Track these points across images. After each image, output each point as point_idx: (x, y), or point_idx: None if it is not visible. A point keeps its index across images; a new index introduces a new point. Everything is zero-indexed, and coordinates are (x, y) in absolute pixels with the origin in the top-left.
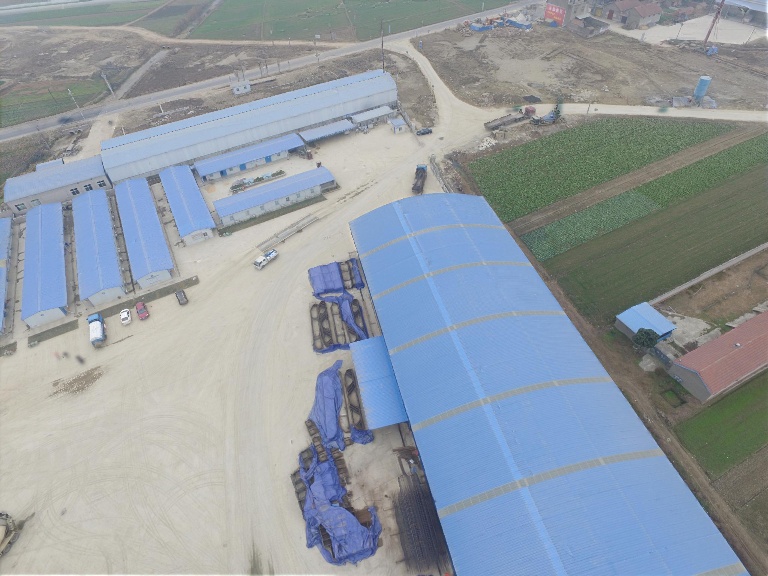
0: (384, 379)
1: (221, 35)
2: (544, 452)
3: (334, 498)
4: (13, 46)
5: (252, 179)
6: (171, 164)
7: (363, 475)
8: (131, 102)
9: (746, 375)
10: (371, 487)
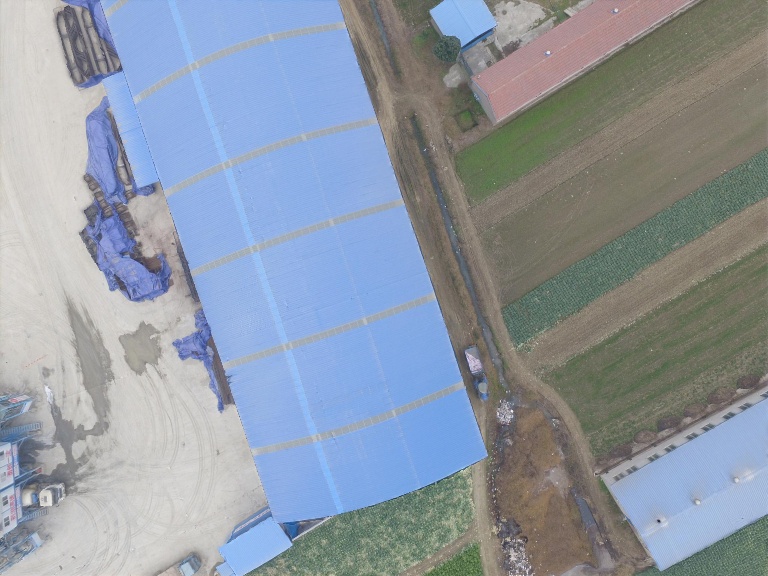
0: None
1: None
2: (277, 218)
3: (125, 250)
4: None
5: None
6: None
7: (149, 226)
8: None
9: (551, 87)
10: (158, 237)
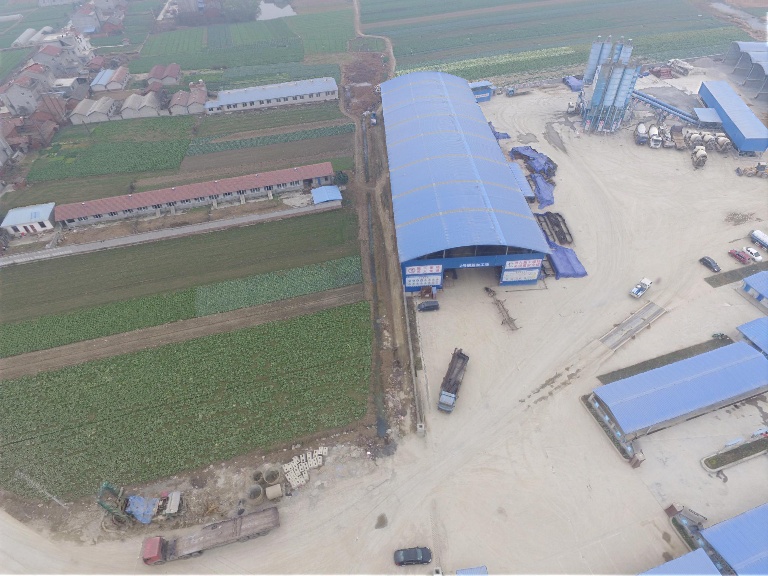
0: None
1: None
2: None
3: None
4: None
5: (756, 434)
6: None
7: None
8: None
9: None
10: None
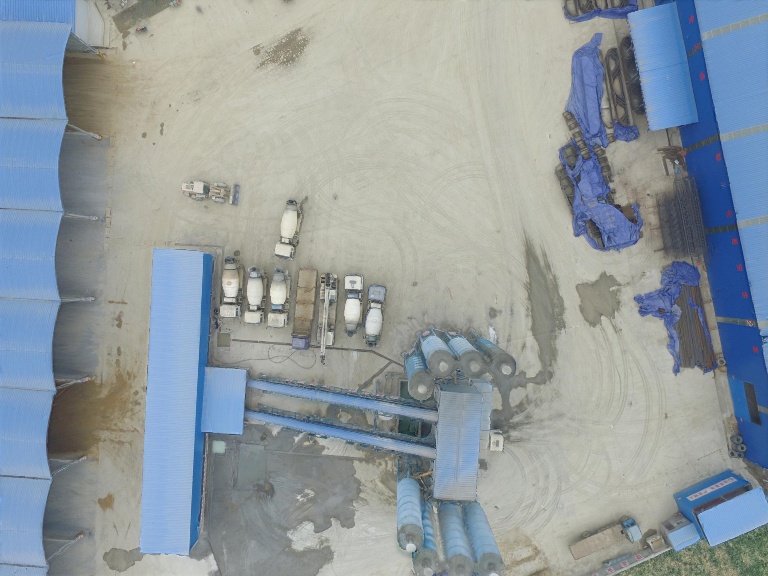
0: (671, 68)
1: None
2: None
3: (599, 195)
4: None
5: None
6: None
7: (626, 174)
8: None
9: None
10: (634, 186)
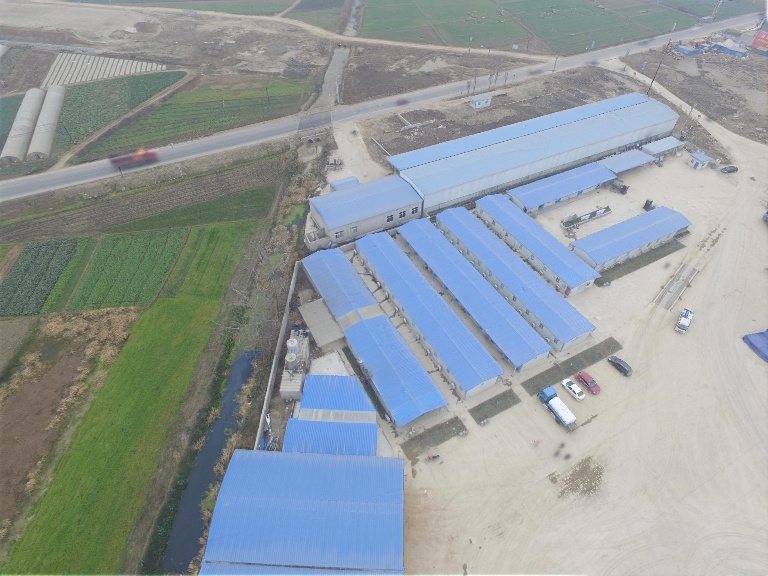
0: None
1: (395, 36)
2: None
3: None
4: (168, 31)
5: (588, 216)
6: (477, 191)
7: None
8: (359, 109)
9: None
10: None
